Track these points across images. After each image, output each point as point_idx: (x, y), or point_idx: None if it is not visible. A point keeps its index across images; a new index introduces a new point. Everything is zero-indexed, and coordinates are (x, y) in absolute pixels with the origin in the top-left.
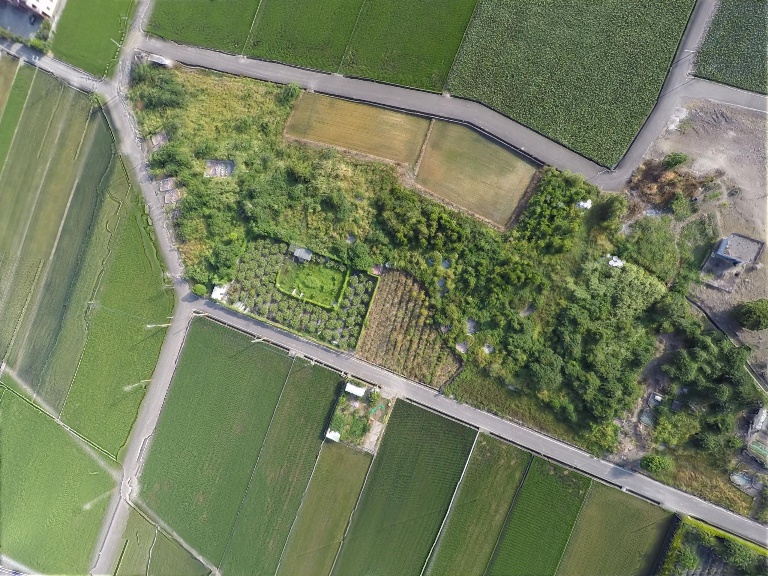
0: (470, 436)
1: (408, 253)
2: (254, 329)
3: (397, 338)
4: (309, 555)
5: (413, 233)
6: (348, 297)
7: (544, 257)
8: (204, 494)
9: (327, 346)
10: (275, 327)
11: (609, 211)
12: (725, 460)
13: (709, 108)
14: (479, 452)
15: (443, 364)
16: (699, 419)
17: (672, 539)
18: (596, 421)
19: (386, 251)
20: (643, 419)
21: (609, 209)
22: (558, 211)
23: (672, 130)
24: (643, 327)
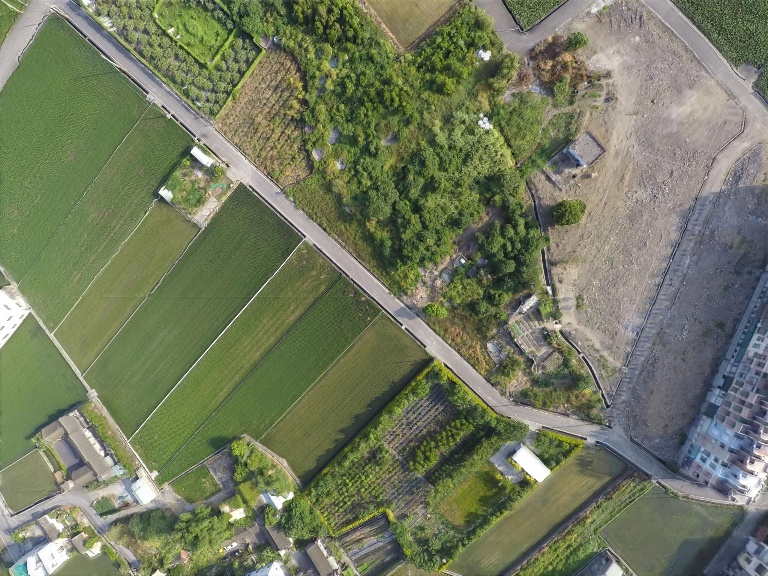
0: (295, 241)
1: (300, 34)
2: (116, 55)
3: (261, 122)
4: (112, 299)
5: (311, 11)
6: (226, 60)
7: (424, 91)
8: (19, 209)
9: (188, 103)
10: (139, 62)
11: (499, 68)
12: (489, 328)
13: (634, 5)
14: (297, 257)
15: (295, 166)
16: (485, 288)
17: (421, 374)
18: (403, 259)
19: (279, 22)
20: (444, 275)
21: (500, 66)
22: (455, 48)
23: (593, 14)
24: (478, 193)
